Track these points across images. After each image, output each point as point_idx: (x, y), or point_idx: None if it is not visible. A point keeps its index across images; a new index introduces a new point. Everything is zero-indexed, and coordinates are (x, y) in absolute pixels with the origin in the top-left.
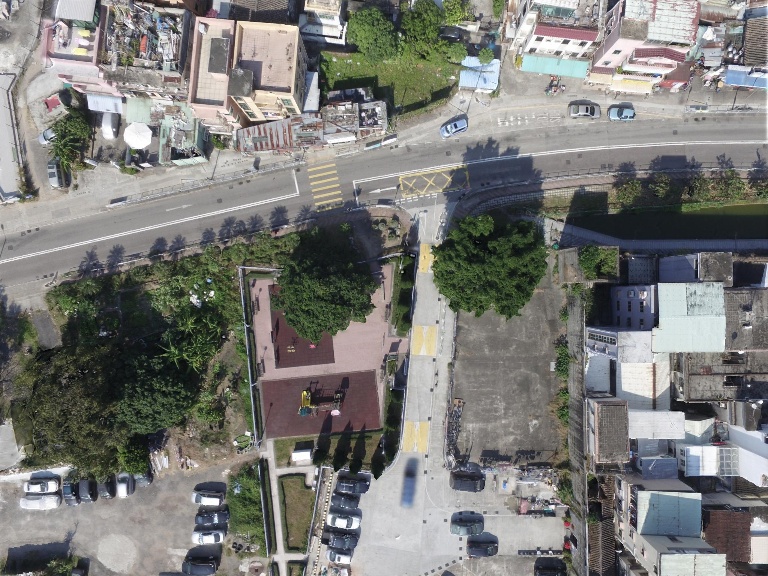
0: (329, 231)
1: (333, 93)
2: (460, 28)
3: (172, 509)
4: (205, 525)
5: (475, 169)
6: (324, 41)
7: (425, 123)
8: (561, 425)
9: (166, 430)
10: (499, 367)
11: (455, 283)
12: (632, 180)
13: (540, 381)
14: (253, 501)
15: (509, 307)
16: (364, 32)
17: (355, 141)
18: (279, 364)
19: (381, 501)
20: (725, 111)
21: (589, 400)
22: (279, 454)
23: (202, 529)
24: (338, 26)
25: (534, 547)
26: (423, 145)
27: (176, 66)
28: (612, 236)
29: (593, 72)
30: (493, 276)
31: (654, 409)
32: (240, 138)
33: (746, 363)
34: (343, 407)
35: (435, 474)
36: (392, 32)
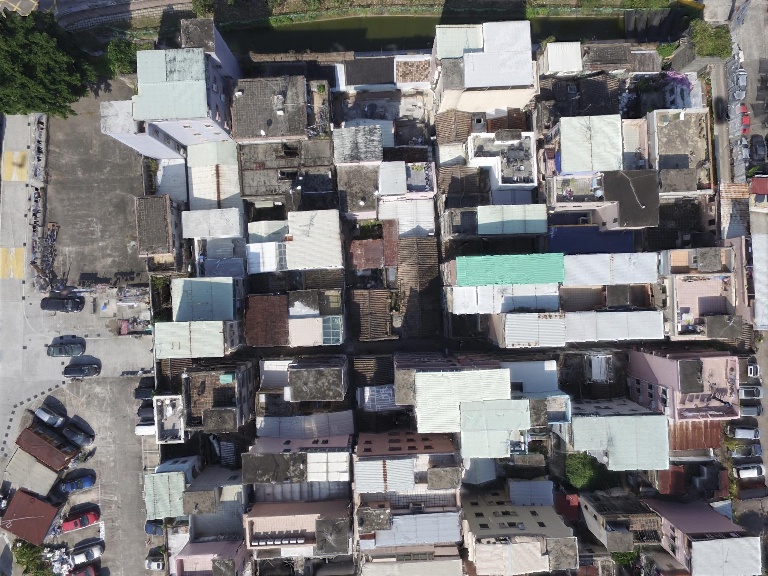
0: None
1: None
2: None
3: None
4: None
5: None
6: None
7: None
8: None
9: None
10: (94, 190)
11: None
12: None
13: None
14: None
15: (24, 97)
16: None
17: None
18: None
19: None
20: None
21: None
22: None
23: None
24: None
25: (138, 368)
26: None
27: None
28: None
29: None
30: None
31: None
32: None
33: (299, 157)
34: None
35: (33, 299)
36: None
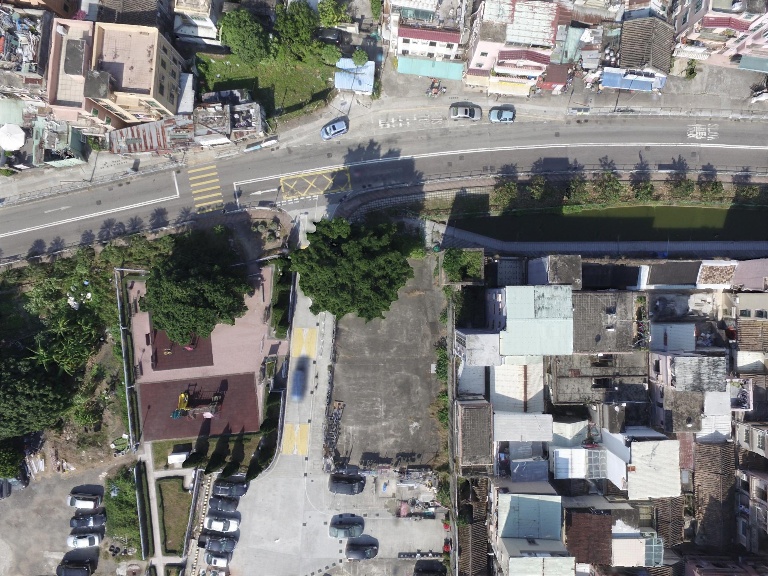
0: (209, 233)
1: (208, 95)
2: (340, 30)
3: (49, 512)
4: (82, 528)
5: (356, 171)
6: (203, 42)
7: (306, 125)
8: (441, 427)
9: (43, 433)
10: (380, 369)
11: (312, 286)
12: (514, 182)
13: (421, 383)
14: (130, 504)
15: (367, 310)
16: (231, 34)
17: (235, 143)
18: (157, 366)
19: (260, 504)
20: (607, 113)
21: (457, 403)
22: (157, 457)
23: (78, 532)
24: (212, 27)
25: (414, 550)
26: (304, 147)
27: (36, 67)
28: (494, 238)
29: (469, 74)
30: (344, 279)
31: (525, 411)
32: (113, 140)
33: (614, 365)
34: (222, 410)
35: (315, 477)
36: (260, 34)
